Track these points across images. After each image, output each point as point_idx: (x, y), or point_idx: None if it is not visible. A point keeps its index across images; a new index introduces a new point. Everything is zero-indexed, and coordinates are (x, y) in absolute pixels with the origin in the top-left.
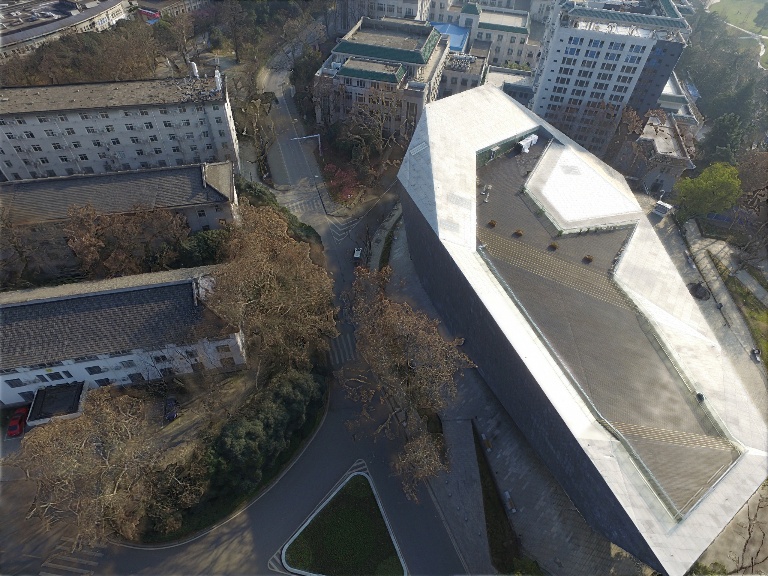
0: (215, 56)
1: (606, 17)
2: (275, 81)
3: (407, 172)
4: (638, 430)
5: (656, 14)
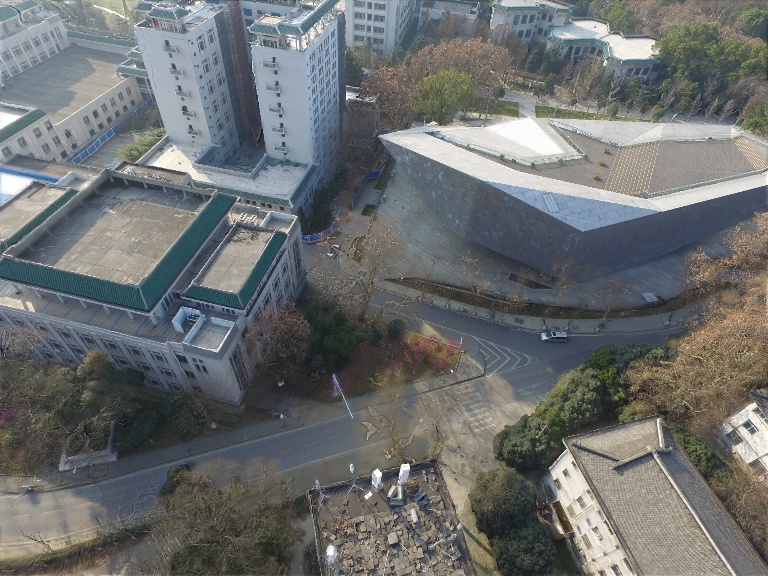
0: (317, 486)
1: (316, 20)
2: (4, 516)
3: (581, 221)
4: (755, 161)
5: (258, 2)
